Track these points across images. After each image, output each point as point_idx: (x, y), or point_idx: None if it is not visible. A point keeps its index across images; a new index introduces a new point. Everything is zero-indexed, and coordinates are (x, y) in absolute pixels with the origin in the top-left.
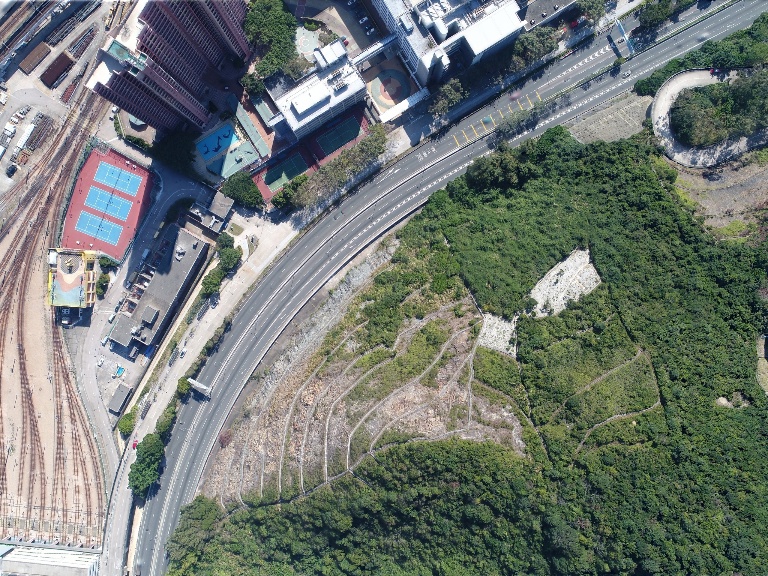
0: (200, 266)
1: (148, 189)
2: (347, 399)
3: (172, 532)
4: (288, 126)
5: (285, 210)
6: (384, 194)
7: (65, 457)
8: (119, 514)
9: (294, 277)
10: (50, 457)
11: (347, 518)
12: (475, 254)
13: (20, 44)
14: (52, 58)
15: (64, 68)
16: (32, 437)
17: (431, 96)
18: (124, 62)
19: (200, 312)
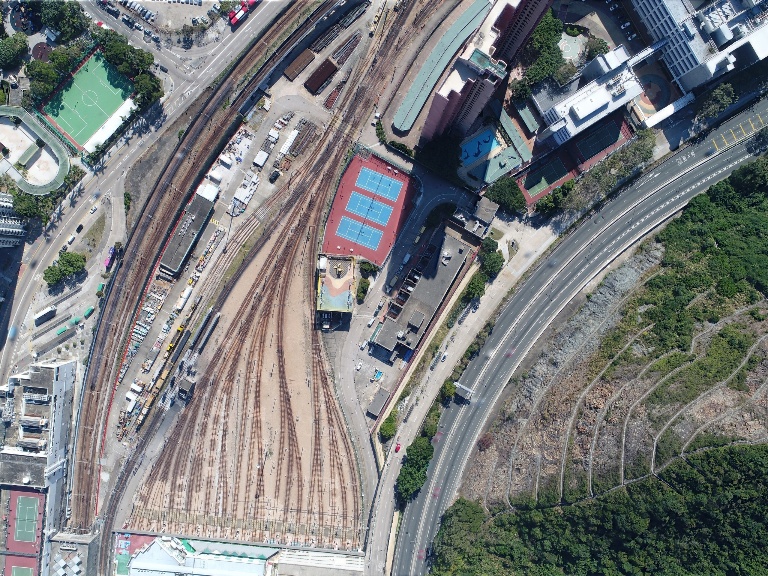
0: (459, 270)
1: (409, 194)
2: (647, 403)
3: (431, 535)
4: (558, 131)
5: (546, 214)
6: (644, 198)
7: (322, 460)
8: (382, 517)
9: (554, 281)
10: (307, 460)
11: (645, 521)
12: (759, 258)
13: (289, 51)
14: (316, 65)
15: (329, 74)
16: (290, 441)
17: (695, 101)
18: (484, 70)
19: (463, 316)
